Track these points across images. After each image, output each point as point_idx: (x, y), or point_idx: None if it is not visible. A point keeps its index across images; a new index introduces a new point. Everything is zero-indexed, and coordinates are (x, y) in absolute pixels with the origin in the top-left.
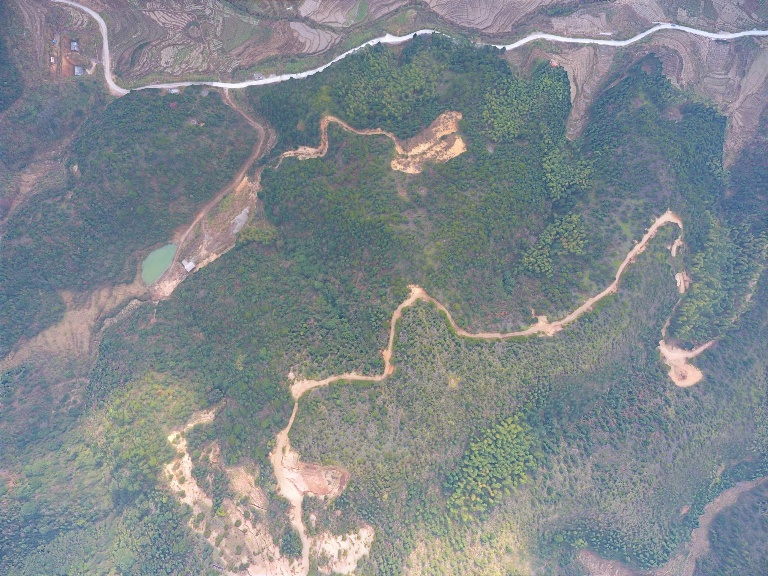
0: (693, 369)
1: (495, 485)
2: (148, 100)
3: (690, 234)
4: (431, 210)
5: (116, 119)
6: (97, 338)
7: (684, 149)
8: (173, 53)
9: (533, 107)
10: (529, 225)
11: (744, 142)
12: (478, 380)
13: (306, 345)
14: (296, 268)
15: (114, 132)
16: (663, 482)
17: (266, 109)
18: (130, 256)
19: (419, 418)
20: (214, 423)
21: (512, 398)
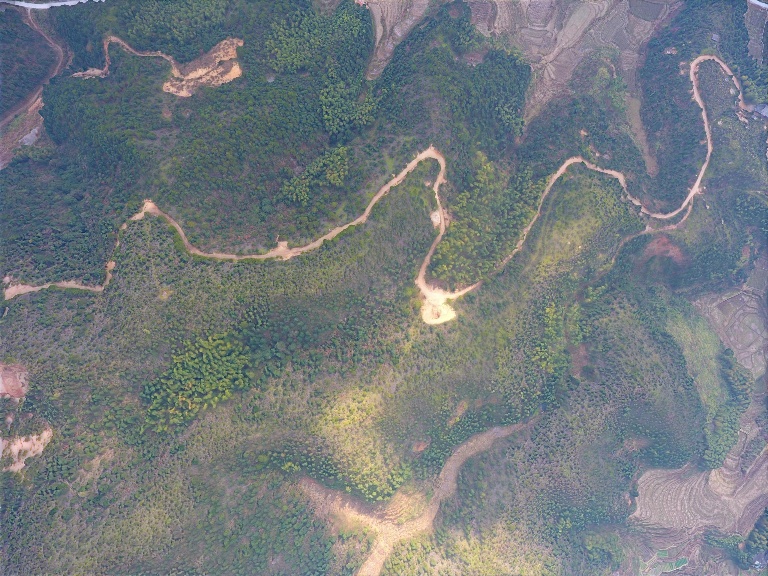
0: (448, 309)
1: (194, 399)
2: None
3: (455, 173)
4: (182, 129)
5: None
6: None
7: (467, 90)
8: None
9: (325, 41)
10: (295, 155)
11: (553, 95)
12: (189, 294)
13: (32, 252)
14: (54, 183)
15: None
16: (382, 412)
17: (62, 30)
18: None
19: (119, 326)
20: None
21: (223, 314)
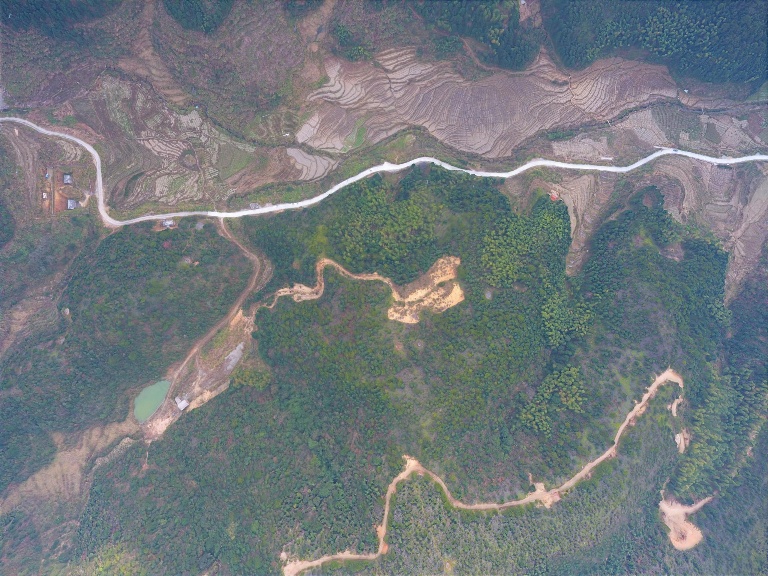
0: (693, 528)
1: None
2: (142, 239)
3: (691, 391)
4: (428, 372)
5: (109, 262)
6: (88, 479)
7: (685, 296)
8: (168, 182)
9: (532, 246)
10: (527, 379)
11: (746, 273)
12: (474, 565)
13: (299, 519)
14: (290, 423)
15: (106, 278)
16: None
17: (262, 243)
18: (122, 395)
19: None
20: None
21: None
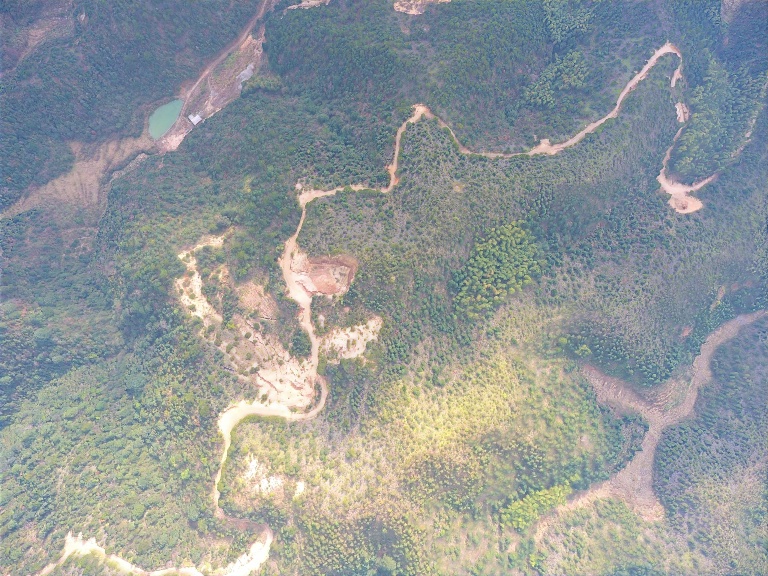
0: (693, 200)
1: (500, 284)
2: None
3: (689, 67)
4: (434, 38)
5: None
6: (106, 189)
7: None
8: None
9: None
10: (530, 62)
11: (742, 1)
12: (482, 185)
13: (313, 162)
14: (301, 104)
15: None
16: (665, 292)
17: None
18: (137, 109)
19: (425, 218)
20: (223, 246)
21: (516, 203)
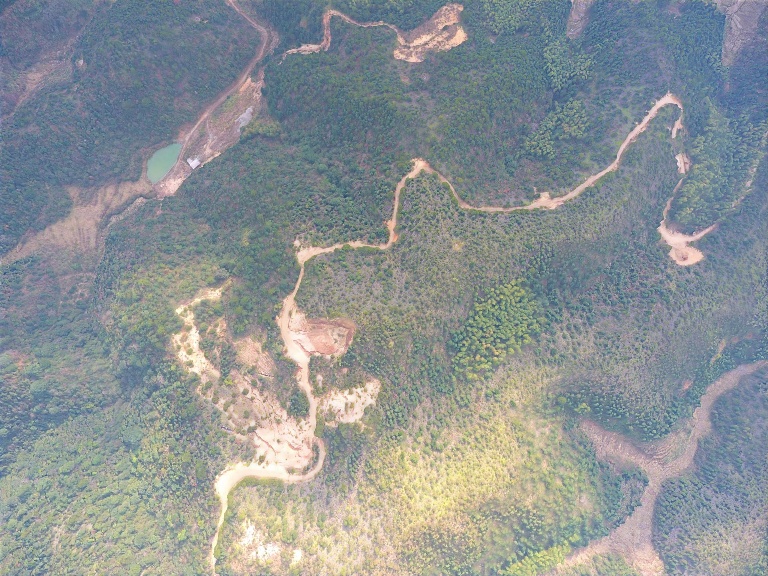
0: (694, 251)
1: (499, 344)
2: None
3: (690, 118)
4: (434, 90)
5: (121, 13)
6: (103, 234)
7: (683, 40)
8: None
9: (533, 3)
10: (530, 111)
11: (743, 44)
12: (482, 243)
13: (311, 217)
14: (300, 154)
15: (119, 24)
16: (665, 349)
17: (269, 9)
18: (135, 153)
19: (424, 278)
20: (221, 299)
21: (515, 261)
